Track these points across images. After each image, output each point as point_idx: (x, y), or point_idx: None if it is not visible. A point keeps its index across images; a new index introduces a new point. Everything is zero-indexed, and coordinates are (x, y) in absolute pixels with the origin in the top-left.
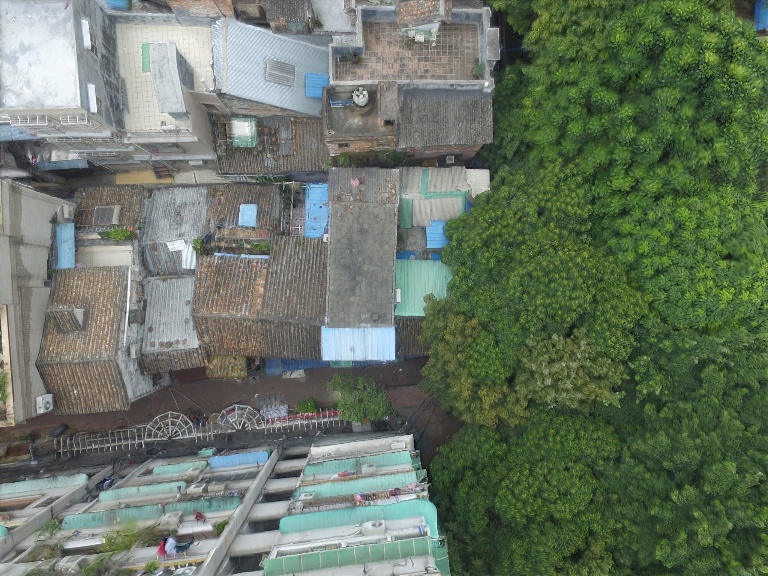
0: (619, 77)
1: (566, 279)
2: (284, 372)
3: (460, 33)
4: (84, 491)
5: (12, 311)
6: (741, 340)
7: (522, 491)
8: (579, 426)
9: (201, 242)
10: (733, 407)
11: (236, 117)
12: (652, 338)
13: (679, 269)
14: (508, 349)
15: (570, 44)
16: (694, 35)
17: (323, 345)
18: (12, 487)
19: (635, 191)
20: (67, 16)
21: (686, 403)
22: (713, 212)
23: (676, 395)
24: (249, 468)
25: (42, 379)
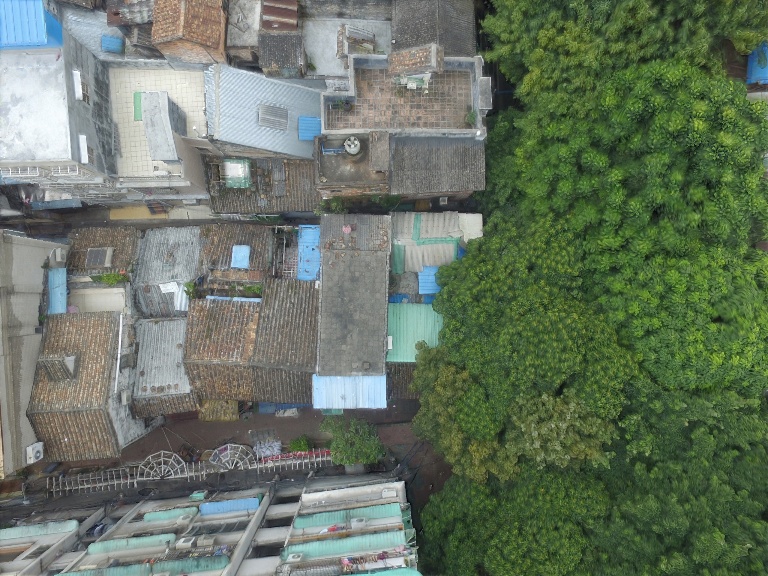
0: (609, 140)
1: (555, 341)
2: (277, 411)
3: (452, 80)
4: (74, 538)
5: (2, 362)
6: (731, 404)
7: (511, 552)
8: (569, 484)
9: (193, 285)
10: (724, 468)
11: (229, 159)
12: (642, 397)
13: (669, 331)
14: (498, 404)
15: (561, 101)
16: (684, 101)
17: (314, 393)
18: (3, 533)
19: (625, 250)
20: (59, 67)
21: (676, 464)
22: (703, 275)
23: (667, 453)
24: (239, 517)
25: (33, 427)
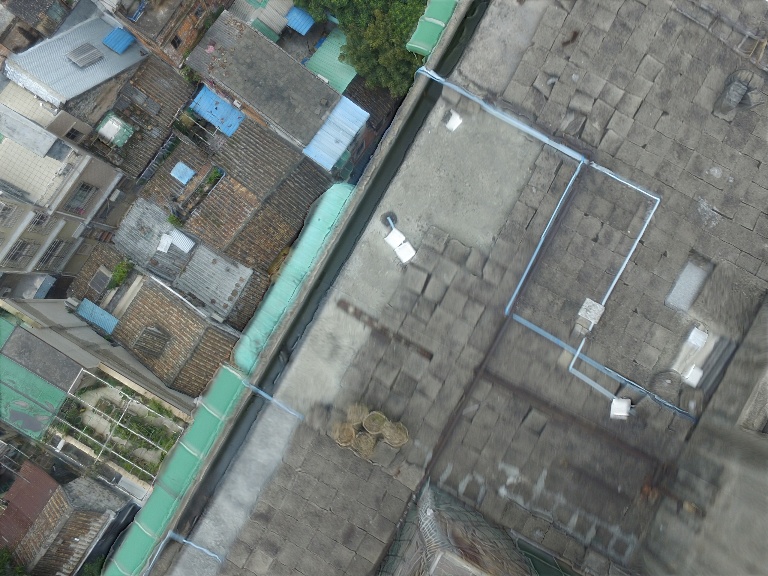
0: None
1: None
2: None
3: None
4: None
5: None
6: None
7: None
8: None
9: (175, 217)
10: None
11: (98, 126)
12: None
13: None
14: None
15: None
16: None
17: (318, 161)
18: None
19: None
20: None
21: None
22: None
23: None
24: None
25: (184, 394)
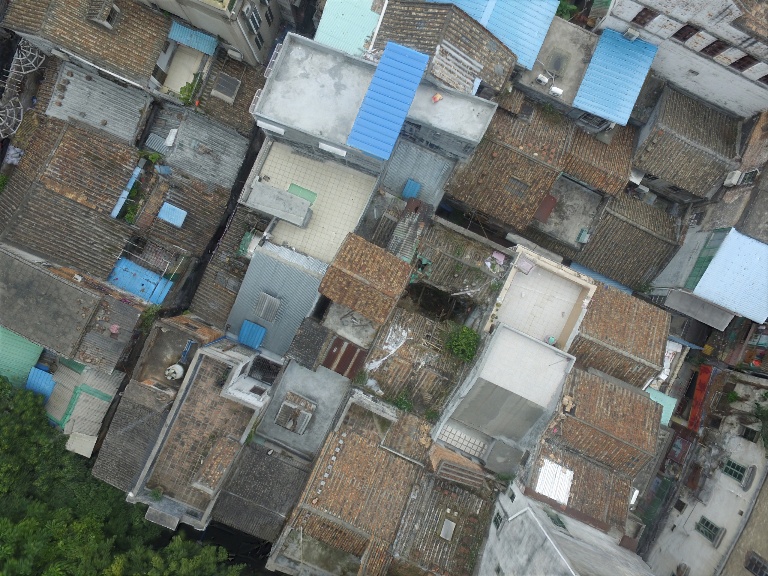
0: None
1: None
2: None
3: None
4: None
5: None
6: None
7: None
8: None
9: None
10: None
11: None
12: None
13: None
14: None
15: None
16: None
17: None
18: None
19: None
20: None
21: None
22: None
23: None
24: None
25: None
